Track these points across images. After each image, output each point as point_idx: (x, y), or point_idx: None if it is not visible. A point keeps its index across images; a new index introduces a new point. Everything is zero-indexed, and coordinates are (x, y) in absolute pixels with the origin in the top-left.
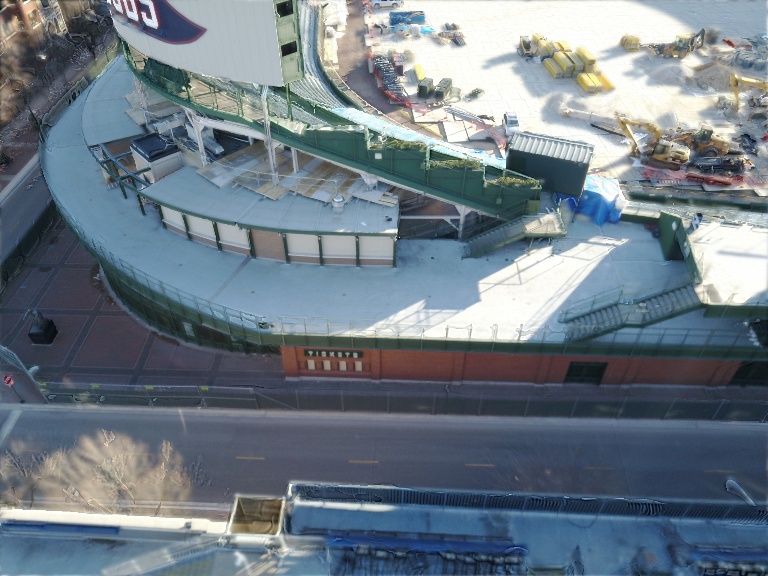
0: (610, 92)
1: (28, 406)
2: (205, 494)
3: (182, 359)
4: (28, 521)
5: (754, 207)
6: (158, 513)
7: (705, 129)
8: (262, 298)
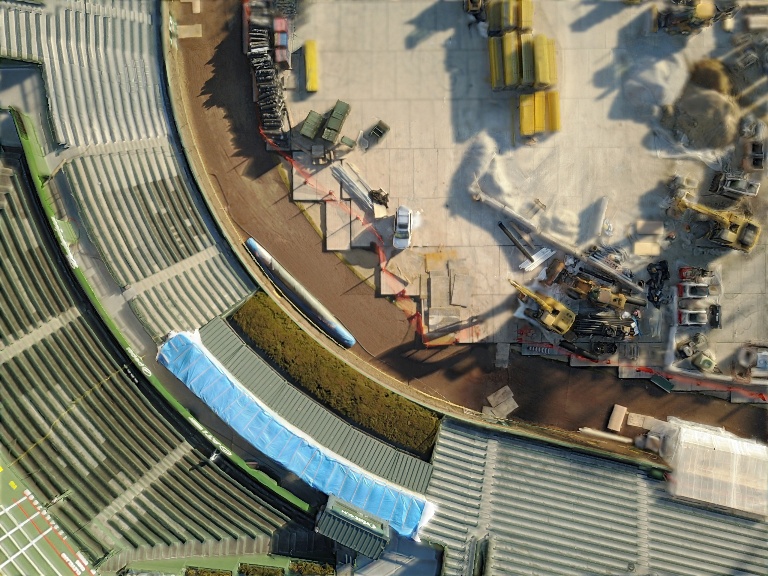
0: (552, 136)
1: None
2: None
3: None
4: None
5: (576, 449)
6: None
7: (600, 301)
8: None
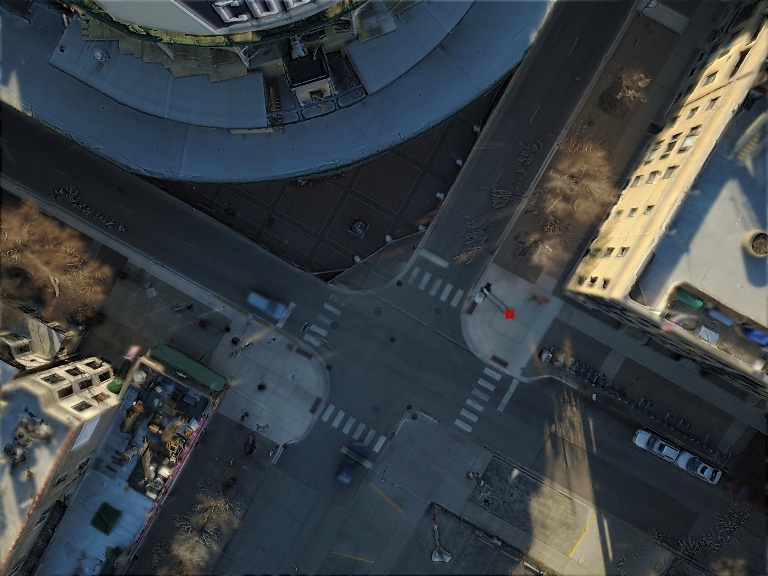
0: None
1: (421, 244)
2: (546, 147)
3: (430, 136)
4: (695, 177)
5: None
6: (546, 176)
7: None
8: (488, 47)
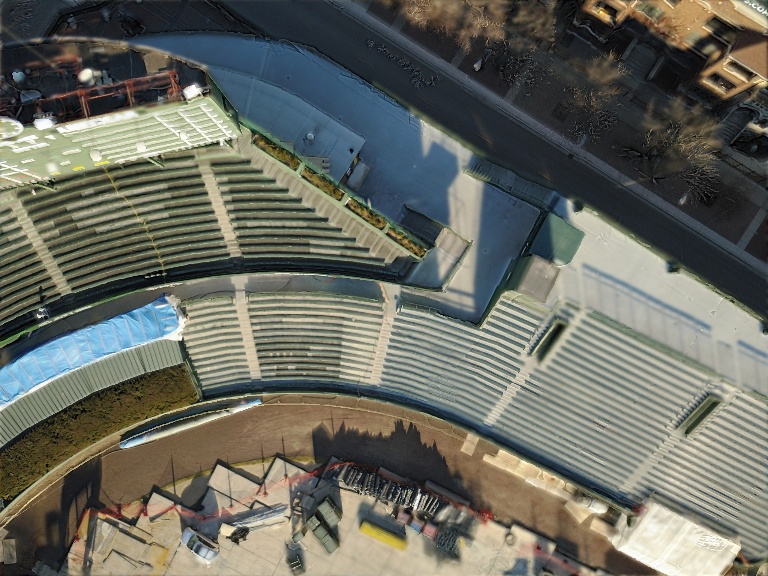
0: None
1: None
2: None
3: None
4: None
5: None
6: None
7: None
8: None
